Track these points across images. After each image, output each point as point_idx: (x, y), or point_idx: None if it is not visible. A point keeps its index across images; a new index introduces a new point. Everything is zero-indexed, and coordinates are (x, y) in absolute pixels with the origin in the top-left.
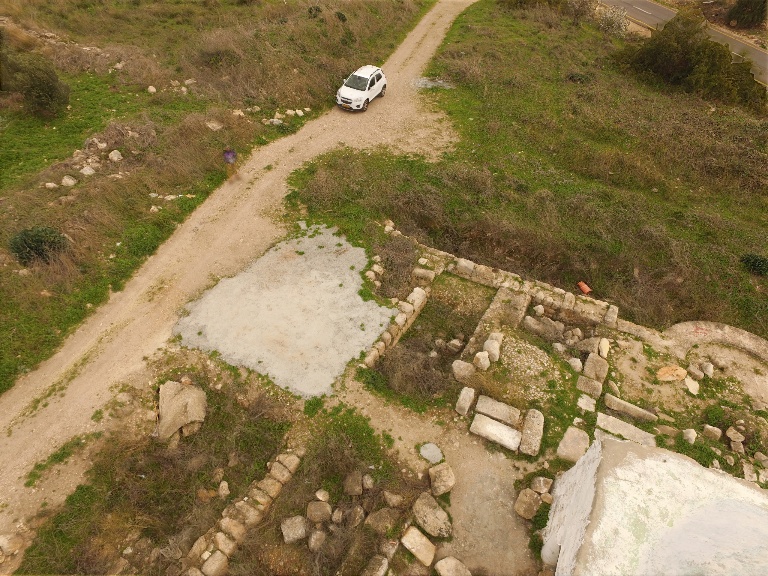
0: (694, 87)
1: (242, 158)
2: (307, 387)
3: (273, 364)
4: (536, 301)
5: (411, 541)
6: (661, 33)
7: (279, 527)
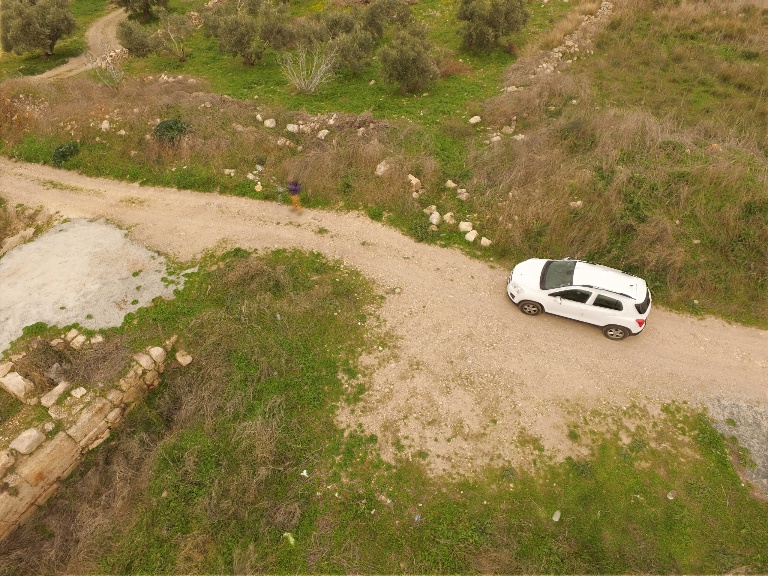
0: None
1: (338, 207)
2: None
3: None
4: None
5: None
6: None
7: None
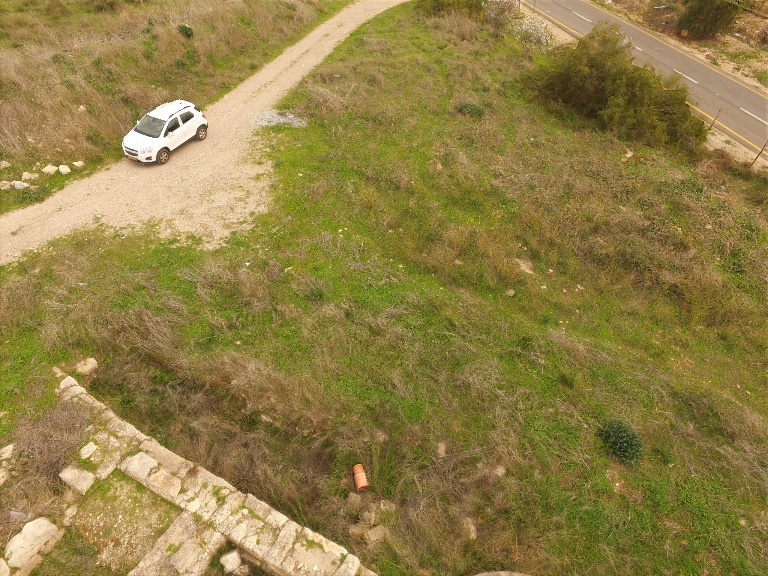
0: (608, 124)
1: None
2: None
3: None
4: (234, 540)
5: None
6: (571, 54)
7: None
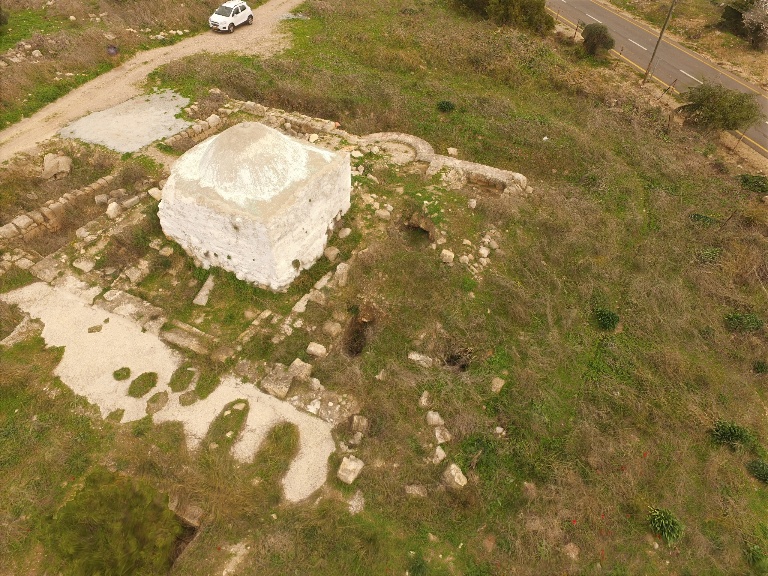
0: (489, 15)
1: (128, 57)
2: (125, 149)
3: (109, 142)
4: (288, 122)
5: (152, 191)
6: None
7: (94, 197)
